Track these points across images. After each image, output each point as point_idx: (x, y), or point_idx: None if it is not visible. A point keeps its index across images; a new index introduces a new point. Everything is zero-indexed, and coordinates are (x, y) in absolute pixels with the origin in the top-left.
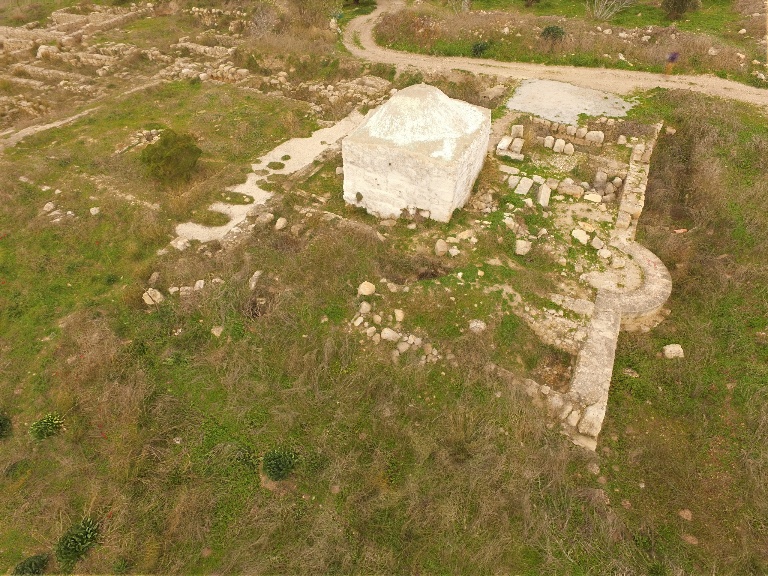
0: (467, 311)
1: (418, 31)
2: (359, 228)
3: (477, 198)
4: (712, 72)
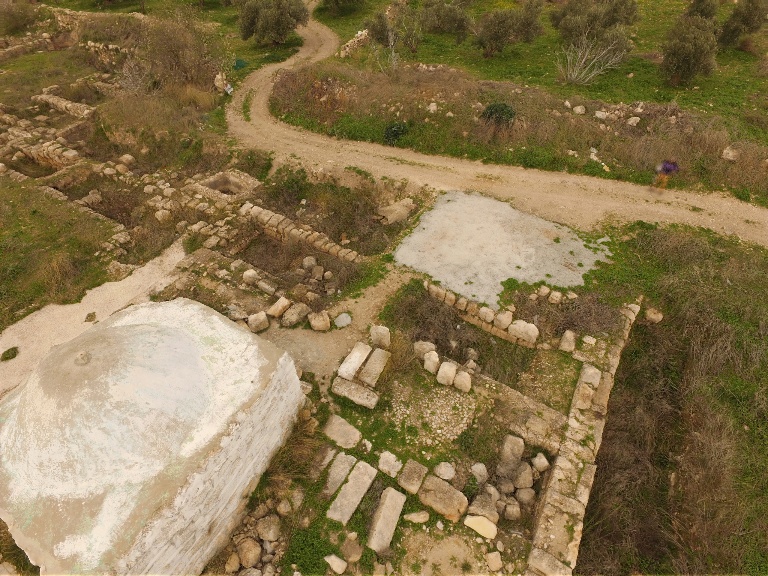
0: None
1: (319, 99)
2: None
3: (256, 520)
4: (727, 189)
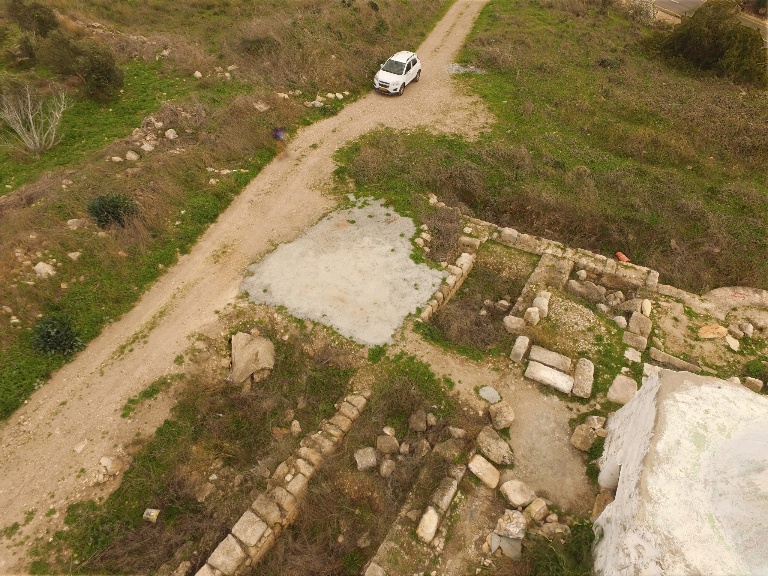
0: None
1: None
2: None
3: None
4: (298, 125)
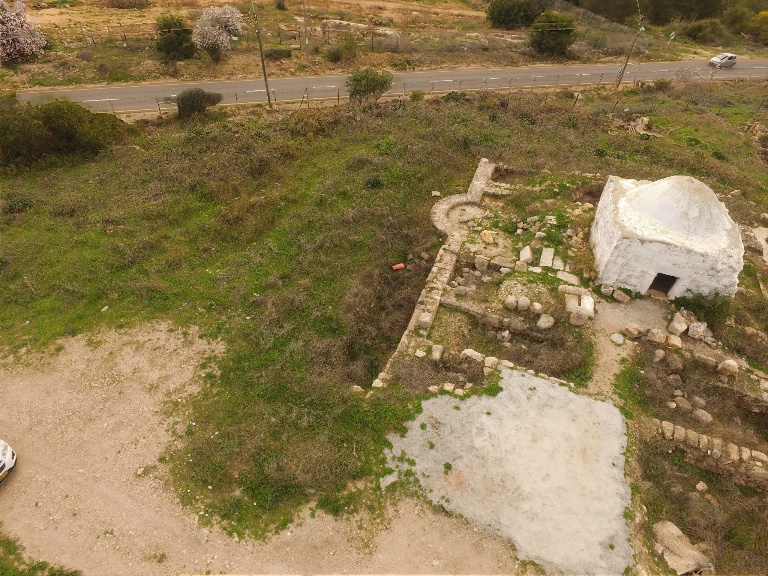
0: None
1: None
2: None
3: None
4: None
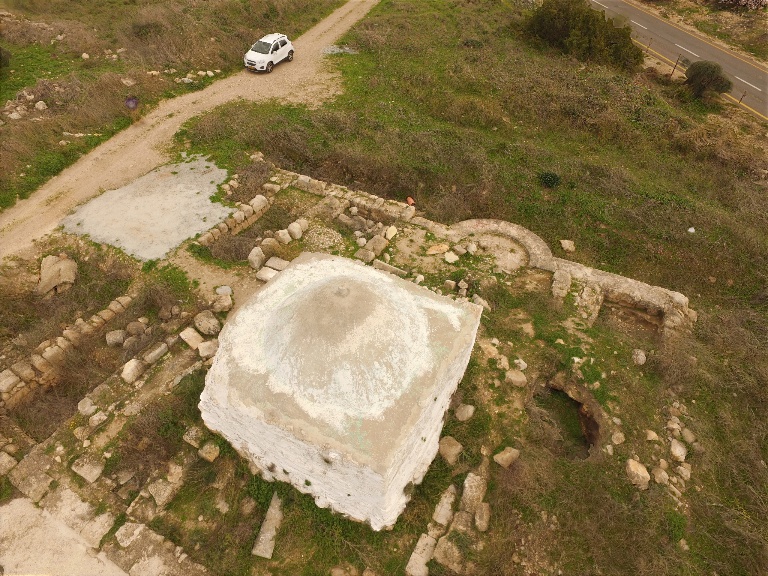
0: (624, 362)
1: None
2: (539, 474)
3: None
4: (161, 97)
